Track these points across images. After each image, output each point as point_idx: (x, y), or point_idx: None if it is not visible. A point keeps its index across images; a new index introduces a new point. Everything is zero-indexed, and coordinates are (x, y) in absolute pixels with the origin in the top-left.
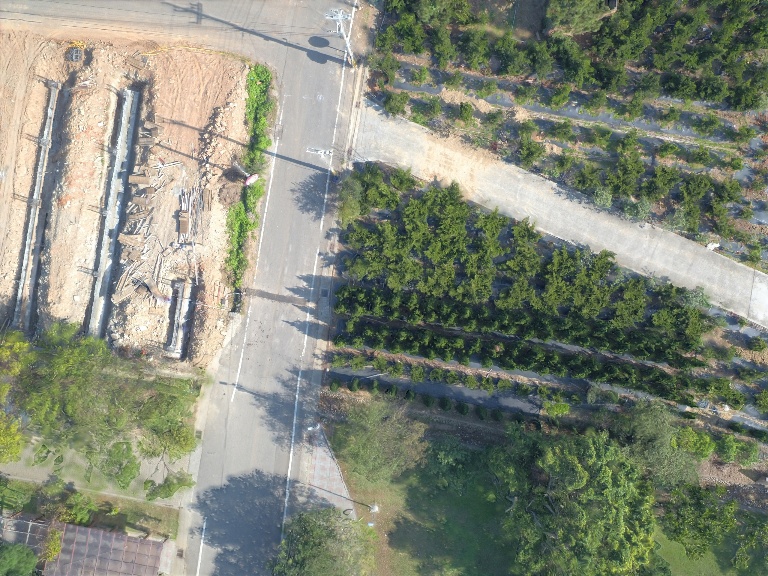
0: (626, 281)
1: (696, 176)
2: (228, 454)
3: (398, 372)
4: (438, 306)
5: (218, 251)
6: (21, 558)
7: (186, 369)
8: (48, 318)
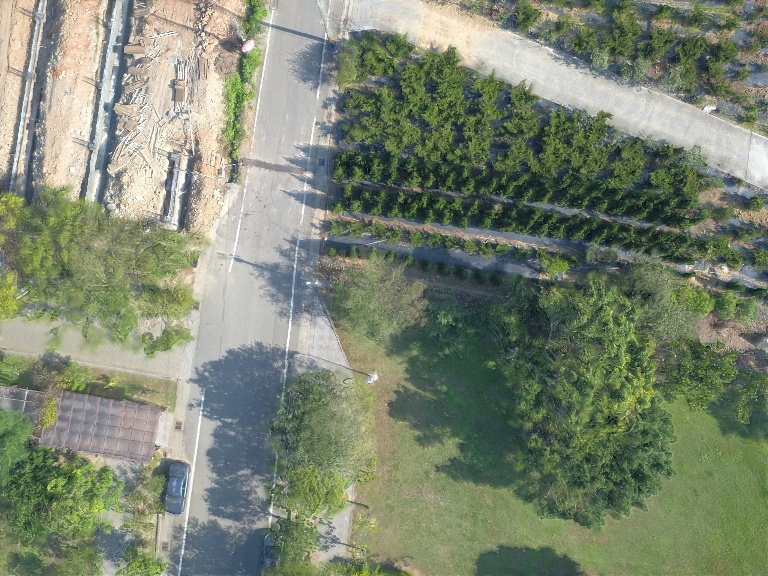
0: (623, 144)
1: (691, 37)
2: (226, 325)
3: (396, 237)
4: (436, 167)
5: (214, 121)
6: (18, 422)
7: (183, 240)
8: (44, 190)
